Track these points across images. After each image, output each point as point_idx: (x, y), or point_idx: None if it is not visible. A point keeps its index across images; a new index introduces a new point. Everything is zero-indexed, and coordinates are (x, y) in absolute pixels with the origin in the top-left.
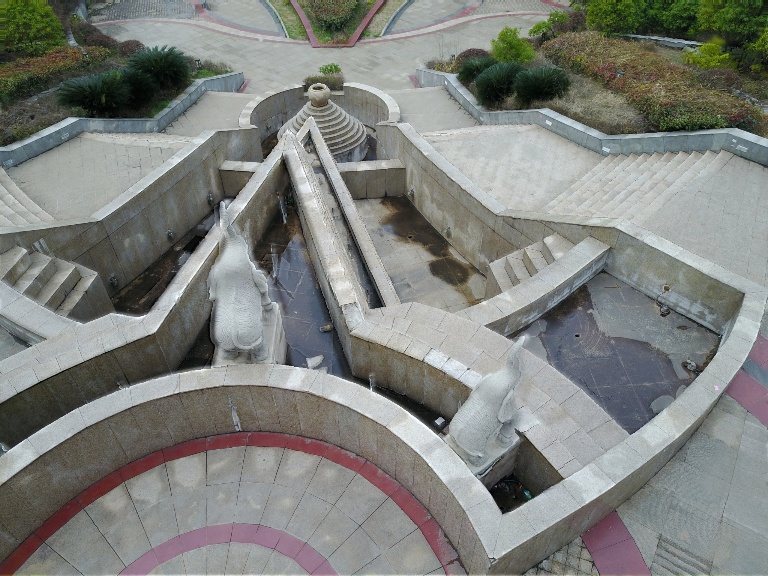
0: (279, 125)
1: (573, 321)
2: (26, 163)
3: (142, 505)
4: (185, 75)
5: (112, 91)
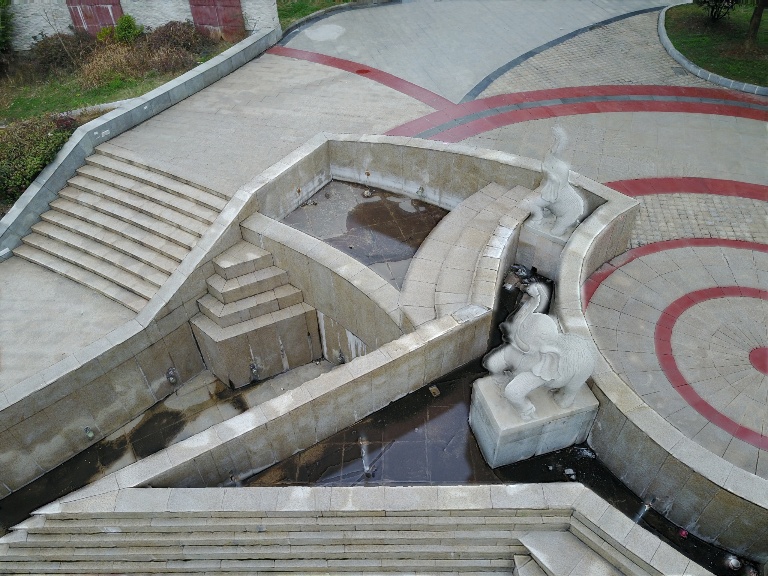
0: None
1: None
2: None
3: None
4: None
5: None
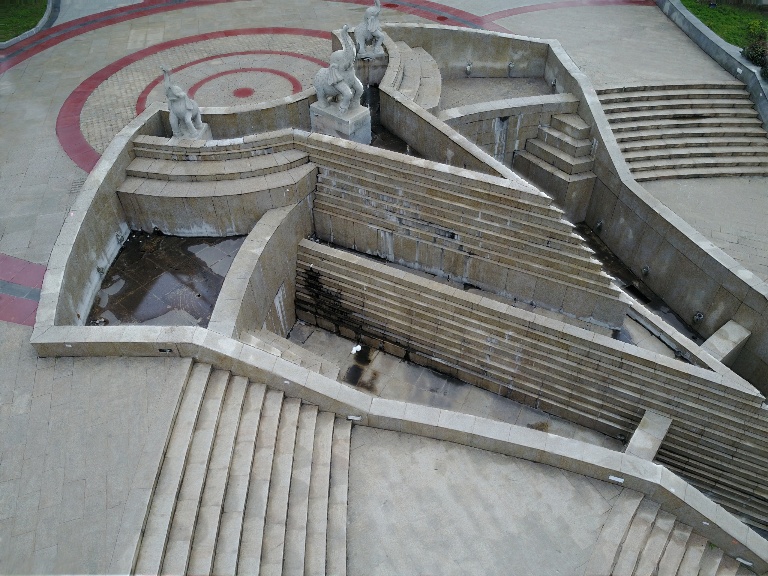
0: None
1: (208, 304)
2: None
3: None
4: None
5: None
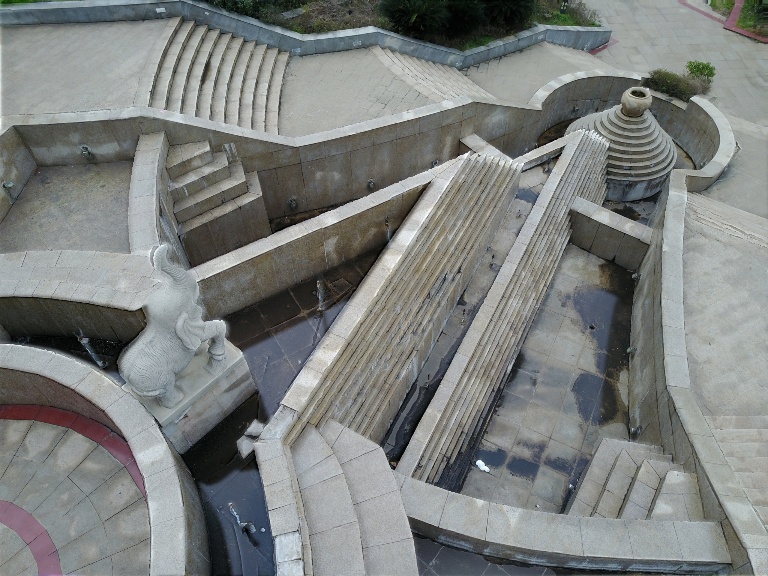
0: (591, 111)
1: None
2: (310, 56)
3: (22, 452)
4: (525, 17)
5: (427, 13)
